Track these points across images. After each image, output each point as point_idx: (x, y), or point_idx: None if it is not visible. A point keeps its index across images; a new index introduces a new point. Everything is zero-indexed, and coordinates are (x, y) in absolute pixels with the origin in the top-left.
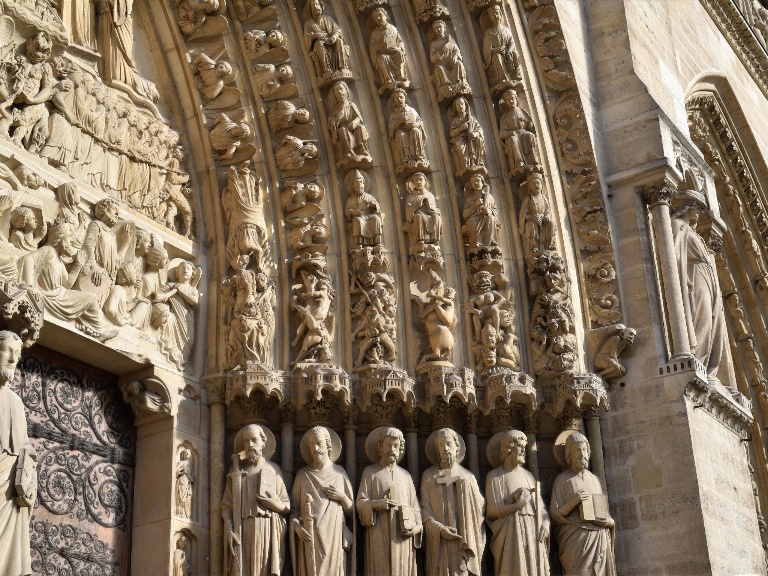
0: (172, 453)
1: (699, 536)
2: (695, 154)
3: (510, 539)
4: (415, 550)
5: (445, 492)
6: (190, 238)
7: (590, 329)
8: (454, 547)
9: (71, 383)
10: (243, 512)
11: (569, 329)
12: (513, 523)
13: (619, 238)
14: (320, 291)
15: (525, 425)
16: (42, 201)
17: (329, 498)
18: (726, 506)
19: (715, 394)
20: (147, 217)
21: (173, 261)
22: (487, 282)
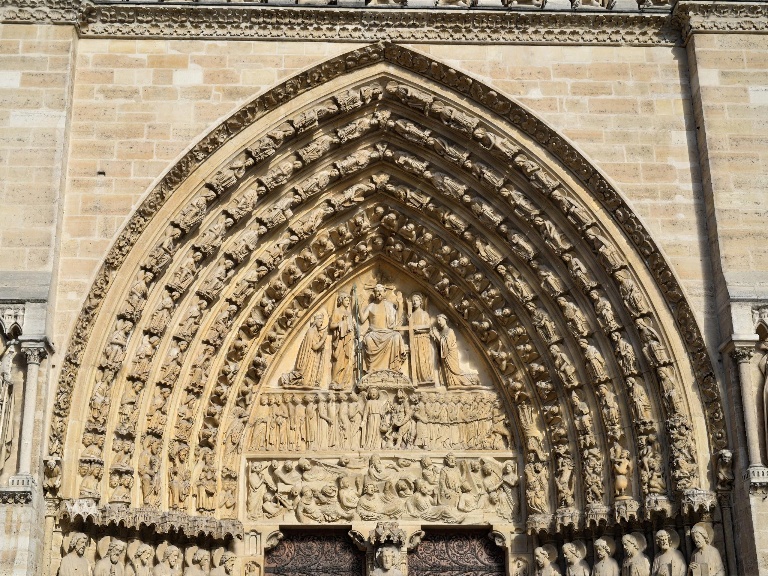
0: (509, 566)
1: None
2: None
3: None
4: None
5: None
6: (510, 448)
7: None
8: None
9: (462, 540)
10: None
11: (693, 460)
12: None
13: None
14: (562, 467)
15: None
16: (412, 471)
17: None
18: None
19: None
20: (479, 450)
21: (505, 463)
22: (642, 443)
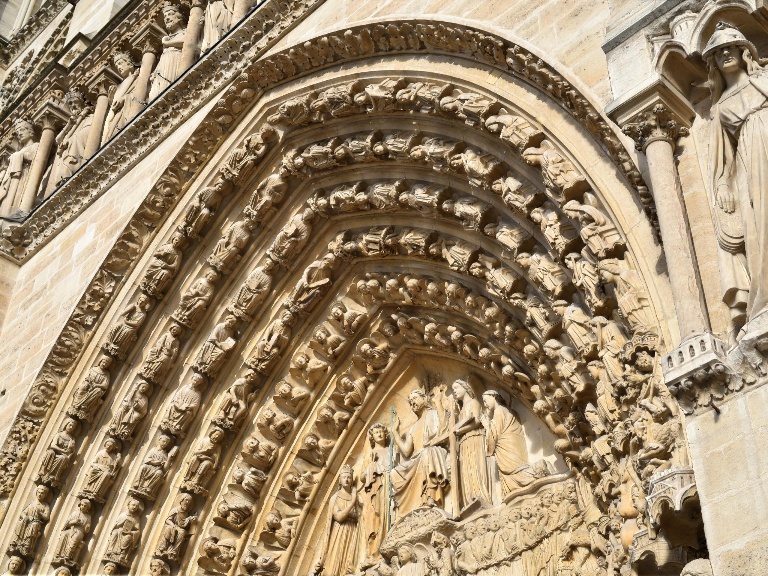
0: None
1: None
2: None
3: None
4: None
5: None
6: None
7: None
8: None
9: None
10: None
11: None
12: None
13: None
14: None
15: None
16: None
17: None
18: None
19: (758, 344)
20: None
21: None
22: None
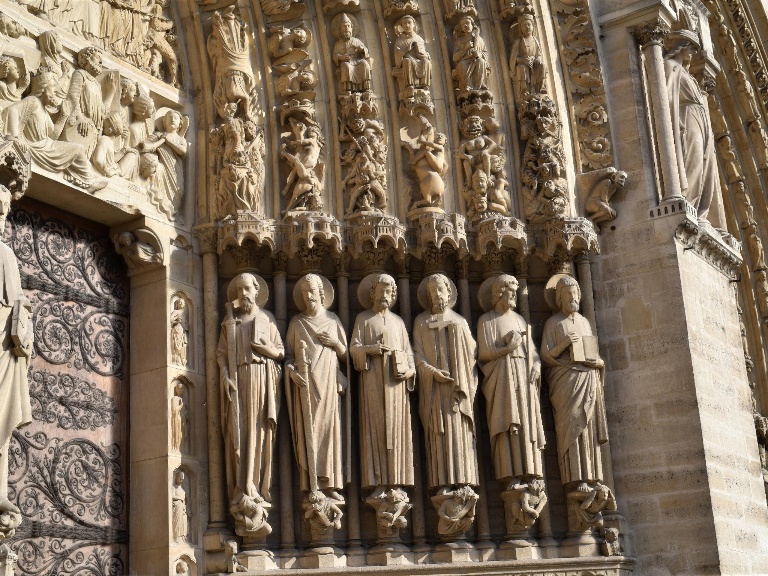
0: (166, 303)
1: (687, 375)
2: None
3: (501, 381)
4: (408, 393)
5: (437, 336)
6: (176, 86)
7: (581, 173)
8: (447, 389)
9: (62, 235)
10: (238, 359)
11: (560, 173)
12: (504, 365)
13: (611, 80)
14: (309, 139)
15: (516, 270)
16: (23, 50)
17: (323, 344)
18: (714, 346)
19: (705, 236)
20: (131, 65)
21: (160, 110)
22: (478, 127)
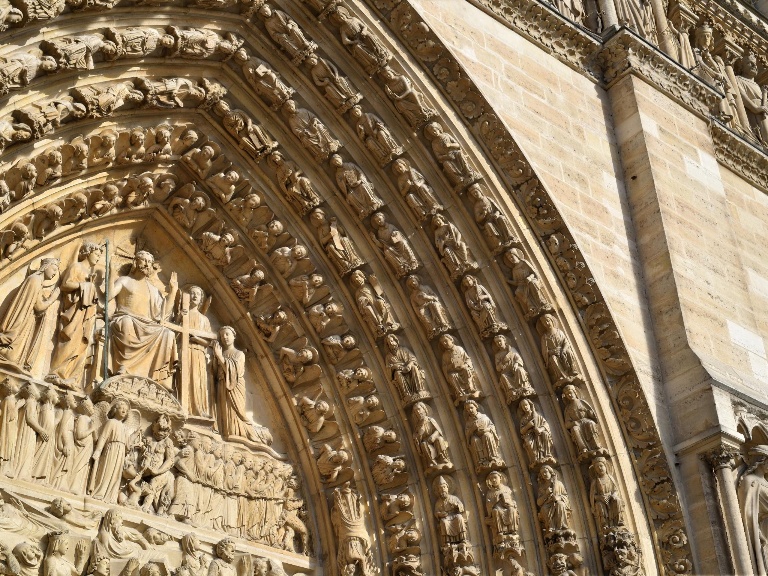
0: None
1: None
2: (767, 408)
3: None
4: None
5: None
6: (307, 554)
7: None
8: None
9: None
10: None
11: None
12: None
13: (689, 503)
14: None
15: None
16: (168, 554)
17: None
18: None
19: None
20: (265, 545)
21: None
22: (562, 564)
